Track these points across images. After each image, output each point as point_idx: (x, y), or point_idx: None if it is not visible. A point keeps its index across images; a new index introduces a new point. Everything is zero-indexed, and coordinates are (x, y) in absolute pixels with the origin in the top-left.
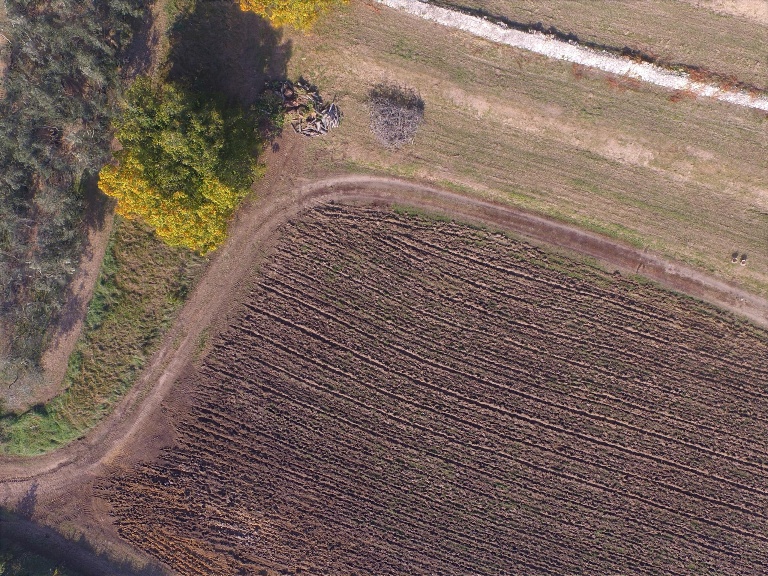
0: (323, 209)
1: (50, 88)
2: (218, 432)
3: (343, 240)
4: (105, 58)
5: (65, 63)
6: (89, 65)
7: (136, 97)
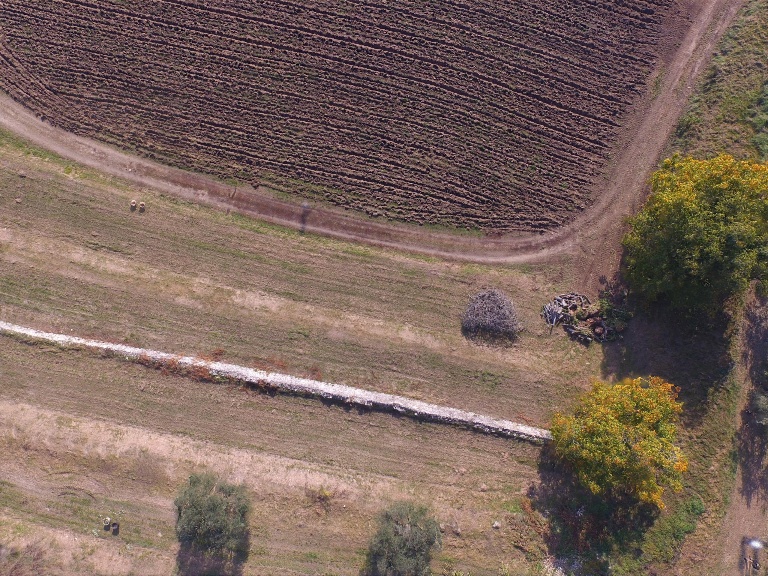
0: (550, 225)
1: None
2: (634, 1)
3: (528, 197)
4: None
5: None
6: None
7: None
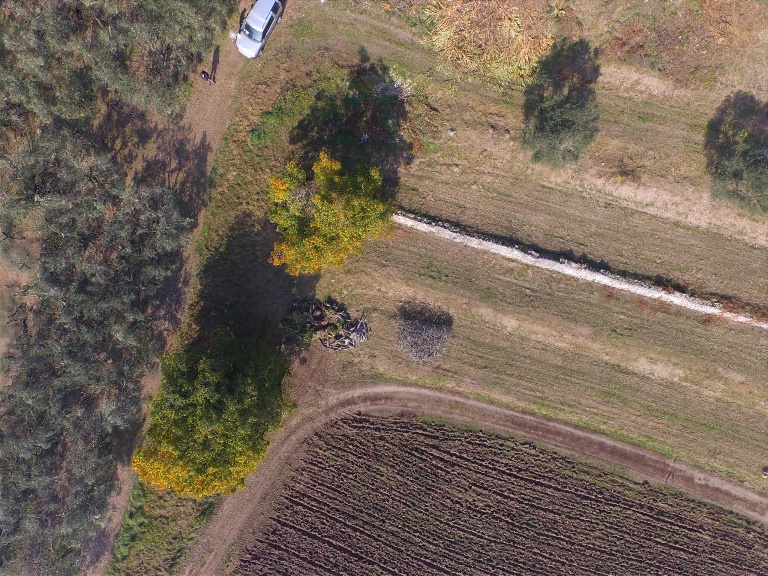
0: (350, 421)
1: (83, 356)
2: None
3: (370, 452)
4: (138, 323)
5: (98, 334)
6: (122, 334)
7: (169, 365)
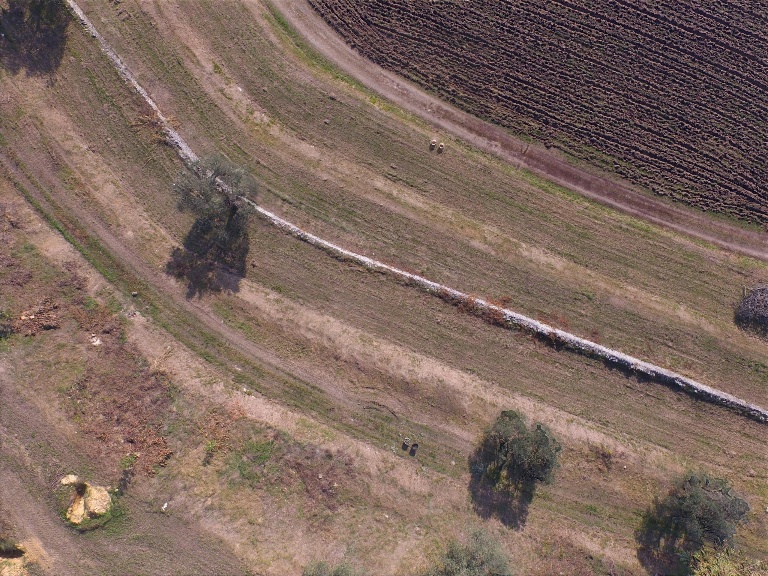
0: None
1: None
2: None
3: None
4: None
5: None
6: None
7: None
